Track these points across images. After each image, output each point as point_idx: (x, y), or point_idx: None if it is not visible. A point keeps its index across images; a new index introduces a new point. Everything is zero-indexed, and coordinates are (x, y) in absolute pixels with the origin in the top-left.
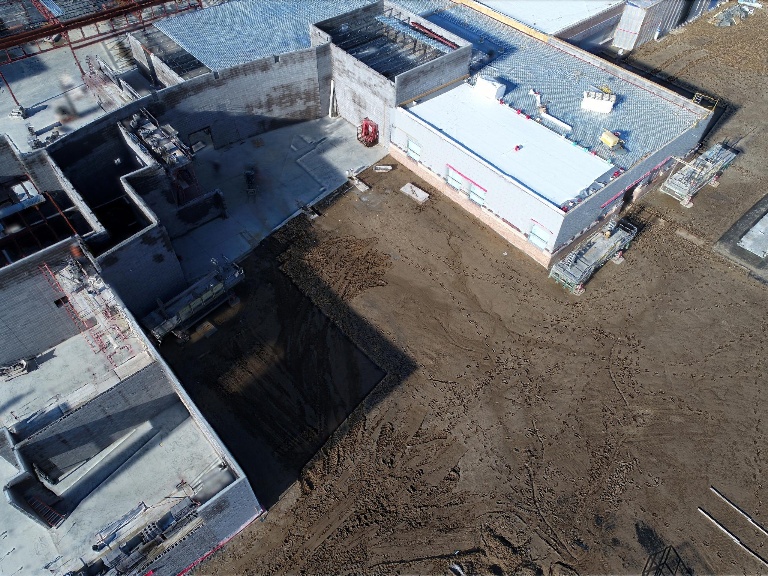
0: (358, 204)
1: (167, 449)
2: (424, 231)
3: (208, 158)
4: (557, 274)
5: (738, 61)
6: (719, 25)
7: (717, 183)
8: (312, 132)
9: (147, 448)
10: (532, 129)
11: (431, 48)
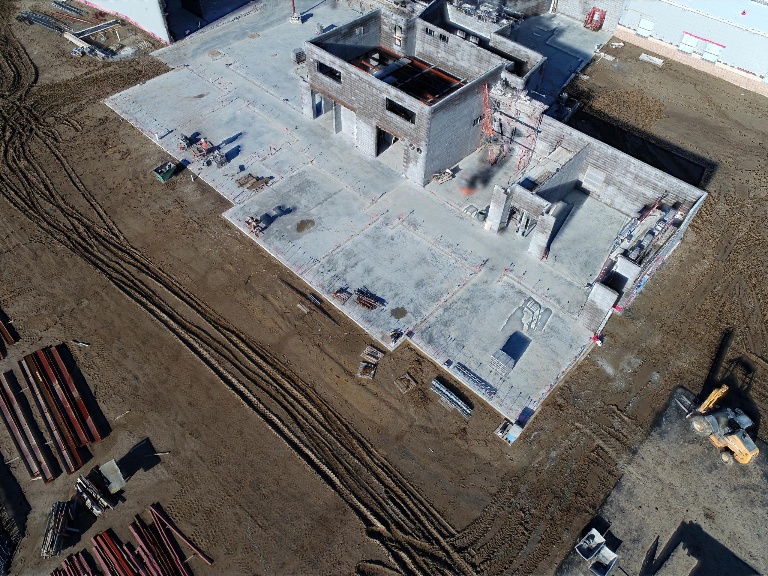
0: (613, 69)
1: (588, 214)
2: (674, 83)
3: None
4: None
5: None
6: None
7: None
8: (543, 24)
9: (573, 215)
10: (743, 2)
11: None
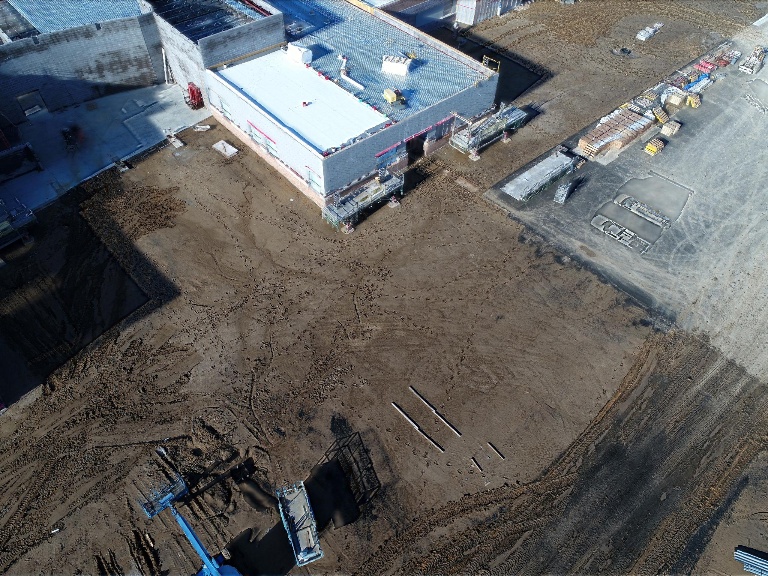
0: (169, 159)
1: None
2: (223, 181)
3: (41, 120)
4: (326, 214)
5: (570, 34)
6: (564, 3)
7: (509, 140)
8: (146, 97)
9: None
10: (327, 89)
11: (247, 17)
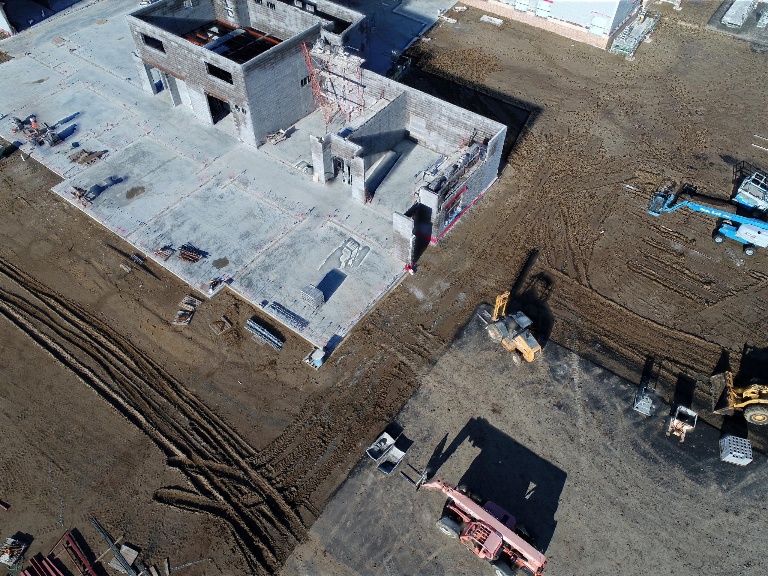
0: (455, 31)
1: (414, 160)
2: (511, 40)
3: None
4: (617, 46)
5: None
6: None
7: None
8: None
9: (400, 162)
10: None
11: None
